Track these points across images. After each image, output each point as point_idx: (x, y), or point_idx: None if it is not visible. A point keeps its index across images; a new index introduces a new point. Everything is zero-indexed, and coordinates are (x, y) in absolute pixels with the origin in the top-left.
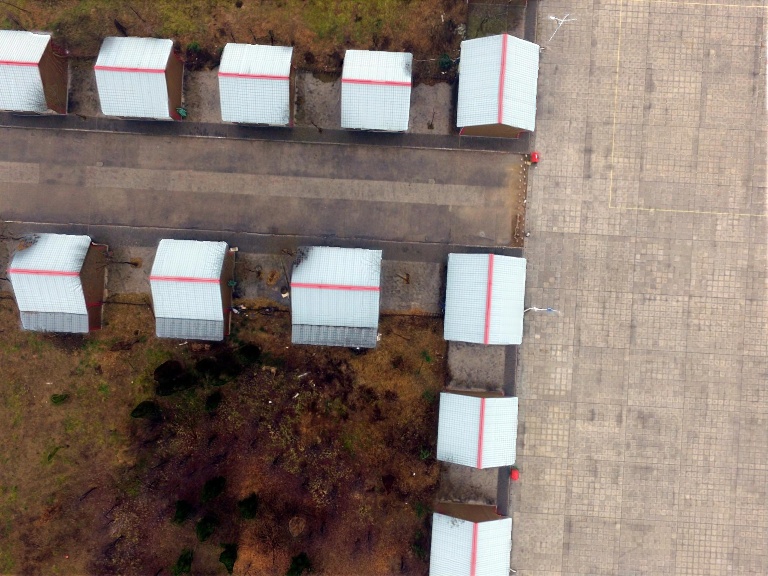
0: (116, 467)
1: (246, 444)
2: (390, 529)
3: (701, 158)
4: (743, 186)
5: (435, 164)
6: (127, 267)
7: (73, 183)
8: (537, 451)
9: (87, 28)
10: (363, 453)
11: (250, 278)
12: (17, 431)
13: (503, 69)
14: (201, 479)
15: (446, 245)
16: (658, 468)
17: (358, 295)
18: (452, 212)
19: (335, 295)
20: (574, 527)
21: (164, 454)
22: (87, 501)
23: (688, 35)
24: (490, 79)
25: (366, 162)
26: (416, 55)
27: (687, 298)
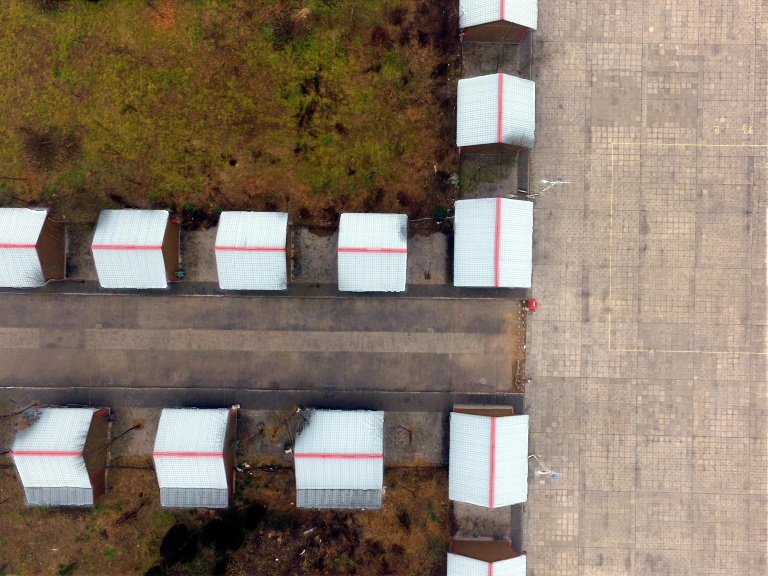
0: None
1: None
2: None
3: (698, 298)
4: (742, 324)
5: (433, 313)
6: None
7: (73, 346)
8: None
9: (83, 192)
10: None
11: (253, 435)
12: None
13: (498, 232)
14: None
15: (447, 394)
16: None
17: (361, 462)
18: (452, 360)
19: (338, 463)
20: None
21: None
22: None
23: (680, 176)
24: (485, 241)
25: (364, 314)
26: (410, 206)
27: (690, 438)
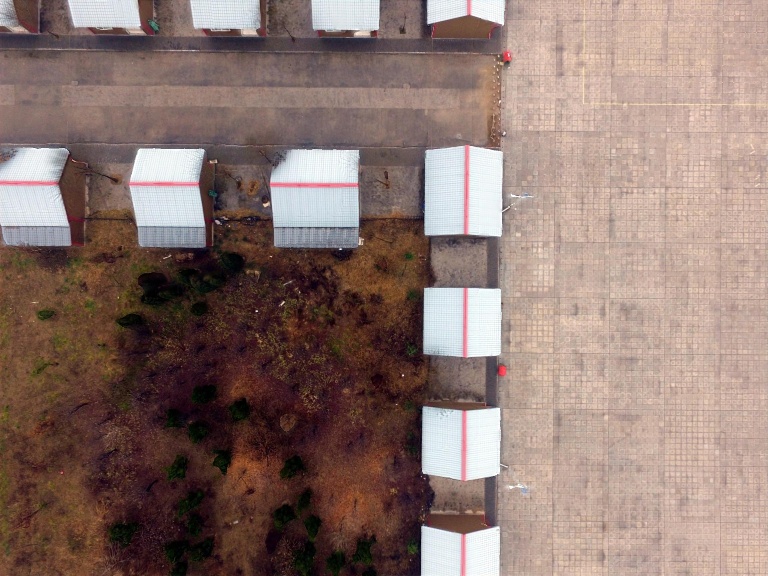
0: (106, 382)
1: (235, 353)
2: (382, 430)
3: (671, 51)
4: (713, 76)
5: (409, 69)
6: (107, 184)
7: (49, 103)
8: (523, 348)
9: None
10: (351, 357)
11: (231, 190)
12: (6, 351)
13: None
14: (192, 390)
15: (424, 148)
16: (643, 358)
17: (337, 192)
18: (428, 116)
19: (314, 194)
20: (563, 420)
21: (154, 367)
22: (79, 417)
23: None
24: None
25: (340, 70)
26: None
27: (664, 190)
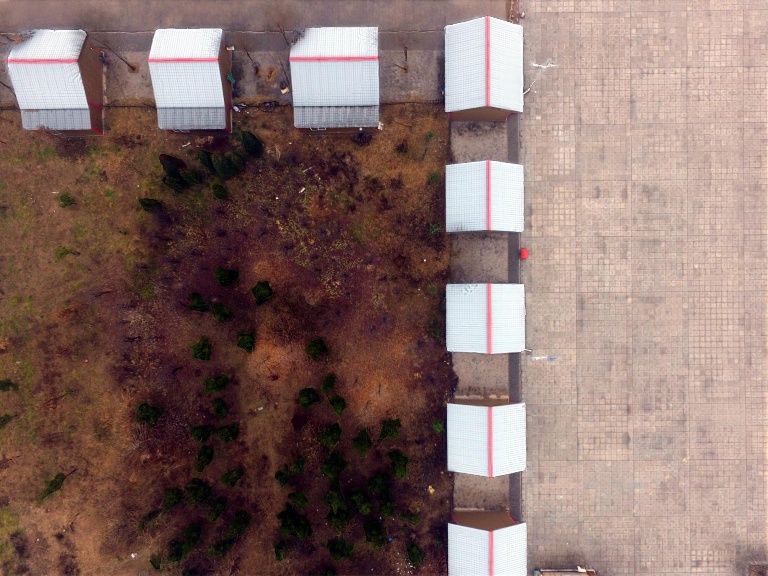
0: (128, 271)
1: (256, 241)
2: (404, 315)
3: None
4: None
5: None
6: (124, 72)
7: None
8: (545, 232)
9: None
10: (373, 243)
11: (248, 76)
12: (27, 242)
13: None
14: (214, 277)
15: (442, 32)
16: (666, 240)
17: (357, 67)
18: None
19: (334, 68)
20: (586, 304)
21: (175, 255)
22: (102, 306)
23: None
24: None
25: None
26: None
27: (685, 70)
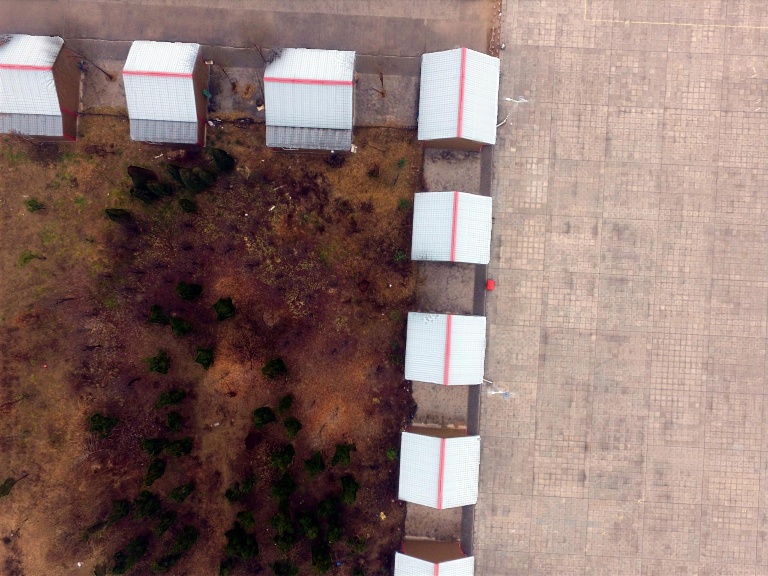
0: (93, 279)
1: (223, 256)
2: (367, 340)
3: None
4: None
5: None
6: (102, 80)
7: None
8: (513, 264)
9: None
10: (339, 265)
11: (225, 92)
12: None
13: None
14: None
15: None
16: (633, 280)
17: (331, 90)
18: (427, 26)
19: (308, 91)
20: (550, 339)
21: (141, 265)
22: (65, 312)
23: None
24: None
25: None
26: None
27: (662, 110)
